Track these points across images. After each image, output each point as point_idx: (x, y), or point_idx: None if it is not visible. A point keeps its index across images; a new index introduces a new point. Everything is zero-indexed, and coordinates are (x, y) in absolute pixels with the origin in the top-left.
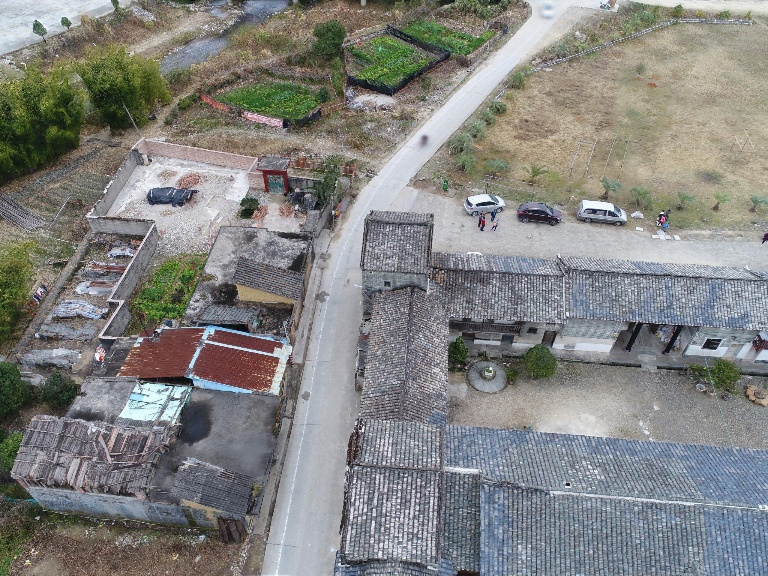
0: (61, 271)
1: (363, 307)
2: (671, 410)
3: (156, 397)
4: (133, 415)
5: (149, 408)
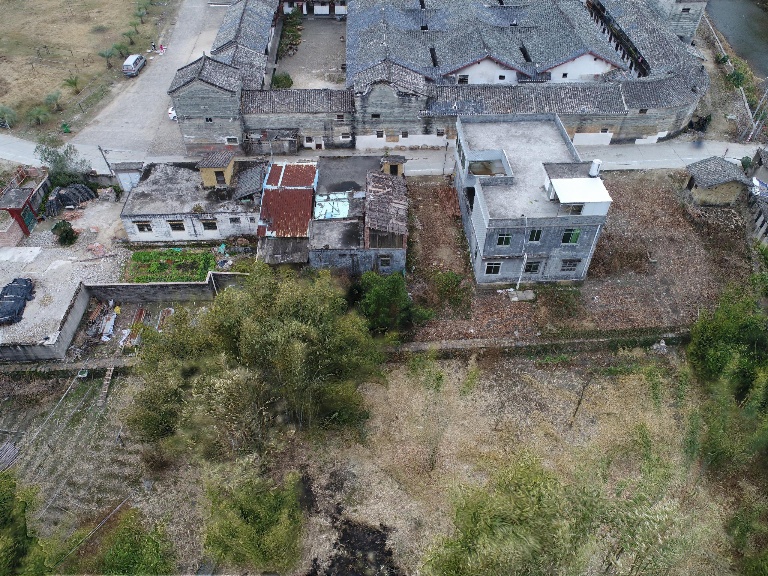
0: (122, 382)
1: (237, 136)
2: (304, 64)
3: (327, 206)
4: (345, 211)
5: (338, 206)
